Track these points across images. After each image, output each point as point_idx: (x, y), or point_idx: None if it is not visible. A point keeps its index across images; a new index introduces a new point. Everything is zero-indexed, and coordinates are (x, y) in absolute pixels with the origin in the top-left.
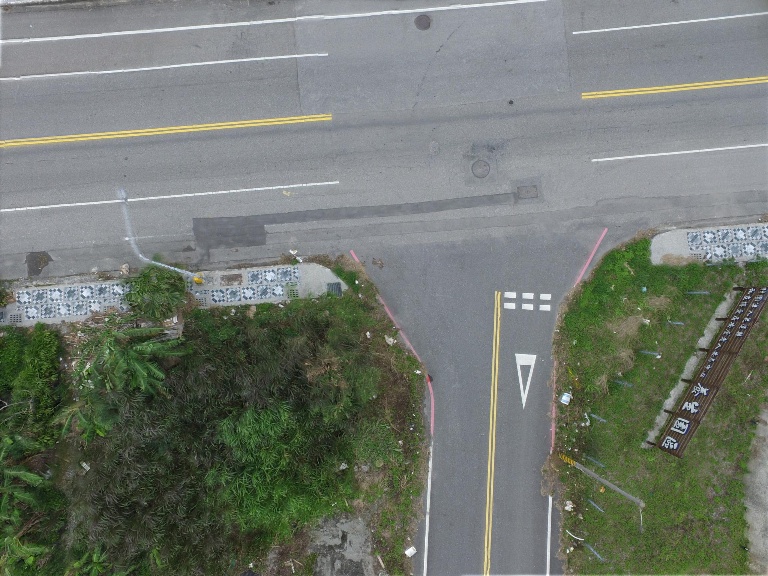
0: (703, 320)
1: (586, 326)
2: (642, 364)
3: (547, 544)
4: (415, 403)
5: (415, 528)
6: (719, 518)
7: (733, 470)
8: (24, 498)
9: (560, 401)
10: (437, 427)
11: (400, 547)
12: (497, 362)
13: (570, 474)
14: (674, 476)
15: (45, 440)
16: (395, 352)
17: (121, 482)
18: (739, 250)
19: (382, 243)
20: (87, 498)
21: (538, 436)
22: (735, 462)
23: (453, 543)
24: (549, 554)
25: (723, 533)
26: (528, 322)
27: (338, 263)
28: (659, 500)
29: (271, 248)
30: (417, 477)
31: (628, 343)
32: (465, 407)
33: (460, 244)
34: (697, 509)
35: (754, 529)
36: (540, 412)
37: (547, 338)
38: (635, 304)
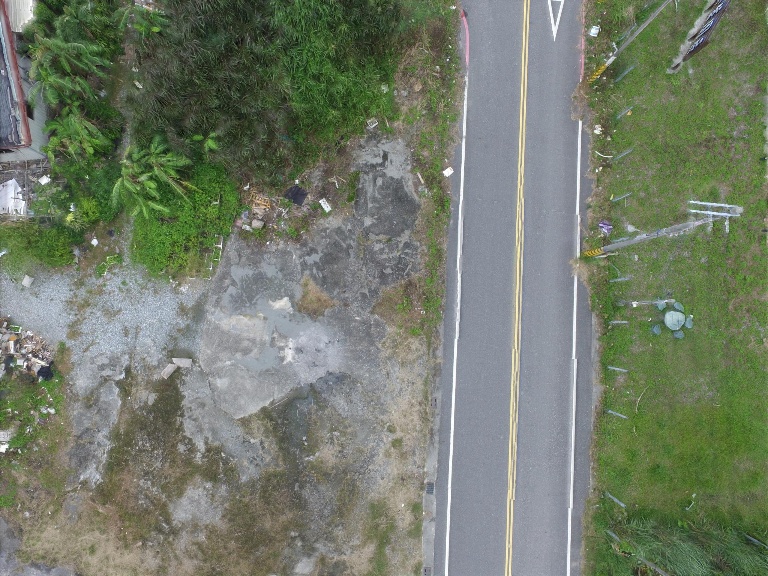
0: None
1: None
2: None
3: (577, 163)
4: (451, 36)
5: (452, 151)
6: (740, 136)
7: (753, 93)
8: (85, 86)
9: (589, 34)
10: (472, 58)
11: (438, 163)
12: None
13: (599, 100)
14: (698, 98)
15: (102, 44)
16: None
17: (178, 65)
18: None
19: None
20: (146, 76)
21: (568, 66)
22: (755, 85)
23: (488, 163)
24: (579, 173)
25: (744, 149)
26: None
27: None
28: (683, 120)
29: None
30: (453, 104)
31: None
32: (499, 39)
33: None
34: (719, 128)
35: None
36: (570, 44)
37: None
38: None
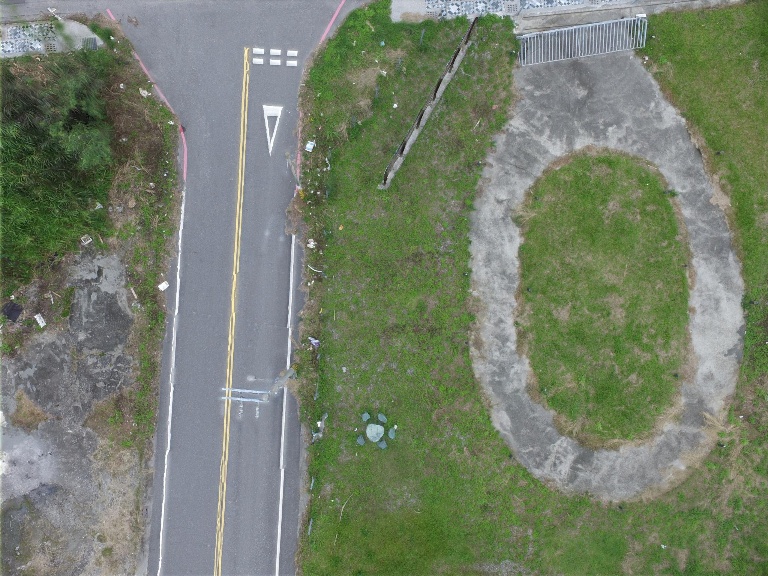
0: (437, 73)
1: (329, 79)
2: (379, 113)
3: (289, 277)
4: (169, 151)
5: (168, 265)
6: (446, 251)
7: (460, 208)
8: None
9: (304, 149)
10: (189, 173)
11: (151, 278)
12: (246, 114)
13: (312, 215)
14: (406, 214)
15: None
16: (149, 103)
17: None
18: (472, 8)
19: (137, 2)
20: None
21: (283, 181)
22: (462, 201)
23: (203, 277)
24: (291, 286)
25: (449, 264)
26: (275, 76)
27: (94, 20)
28: (392, 235)
29: (30, 6)
30: (170, 219)
31: (367, 94)
32: (215, 154)
33: (211, 3)
34: (426, 243)
35: (478, 260)
36: None
37: (293, 91)
38: (373, 57)
